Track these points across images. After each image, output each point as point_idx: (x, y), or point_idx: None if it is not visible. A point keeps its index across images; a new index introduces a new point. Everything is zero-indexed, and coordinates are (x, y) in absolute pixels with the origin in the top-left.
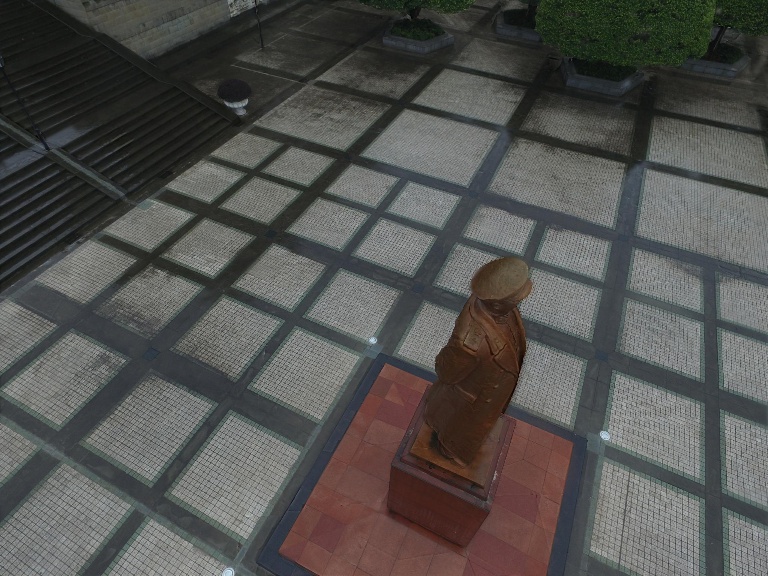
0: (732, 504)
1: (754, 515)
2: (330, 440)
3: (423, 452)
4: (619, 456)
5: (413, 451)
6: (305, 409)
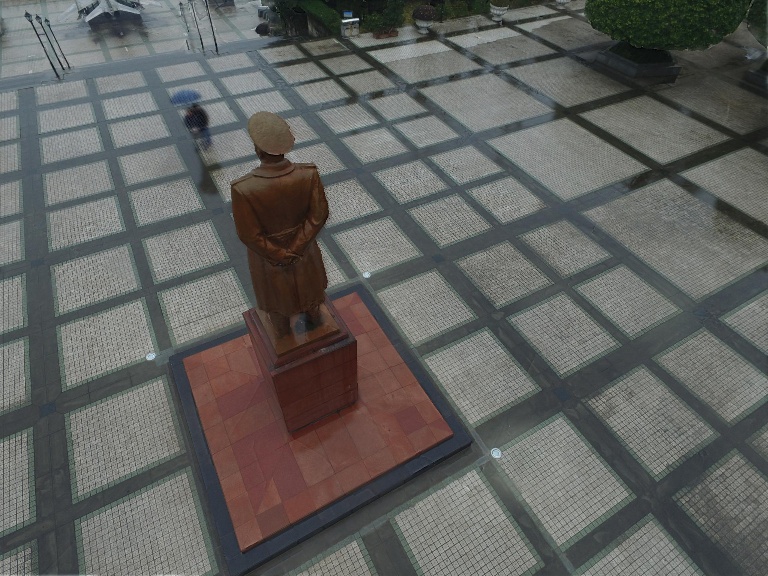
0: (147, 282)
1: (146, 273)
2: (362, 501)
3: (331, 323)
4: (163, 340)
5: (337, 327)
6: (364, 568)
